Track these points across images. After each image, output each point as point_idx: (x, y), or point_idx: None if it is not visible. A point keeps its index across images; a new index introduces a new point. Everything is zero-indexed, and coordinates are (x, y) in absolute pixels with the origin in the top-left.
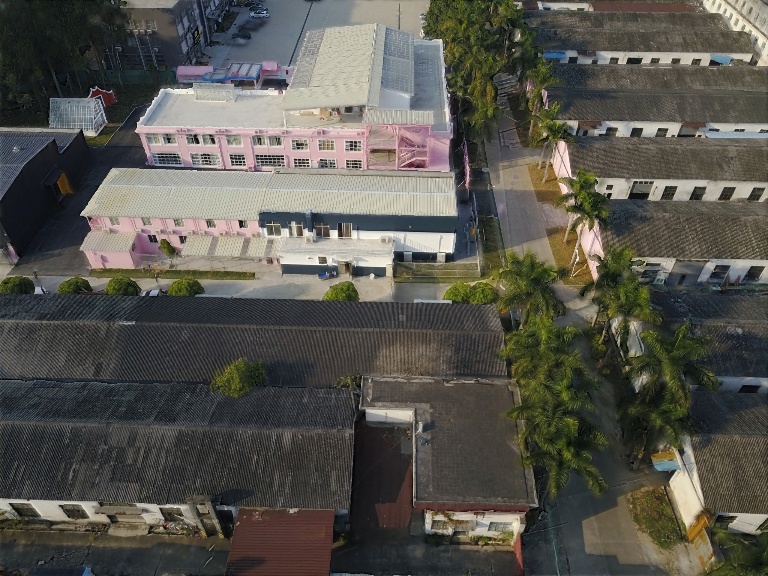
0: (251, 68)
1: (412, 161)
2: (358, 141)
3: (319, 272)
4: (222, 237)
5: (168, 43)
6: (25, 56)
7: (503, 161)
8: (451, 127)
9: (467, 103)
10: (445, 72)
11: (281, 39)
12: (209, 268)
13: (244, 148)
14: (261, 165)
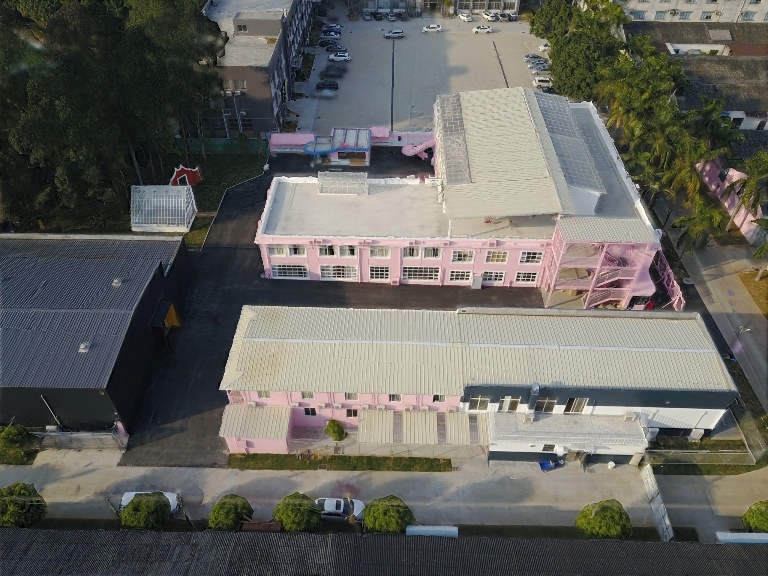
0: (359, 135)
1: (613, 281)
2: (538, 252)
3: (538, 459)
4: (407, 412)
5: (258, 105)
6: (109, 143)
7: (705, 267)
8: (660, 236)
9: (661, 196)
10: (618, 151)
11: (372, 89)
12: (388, 452)
13: (390, 260)
14: (408, 278)
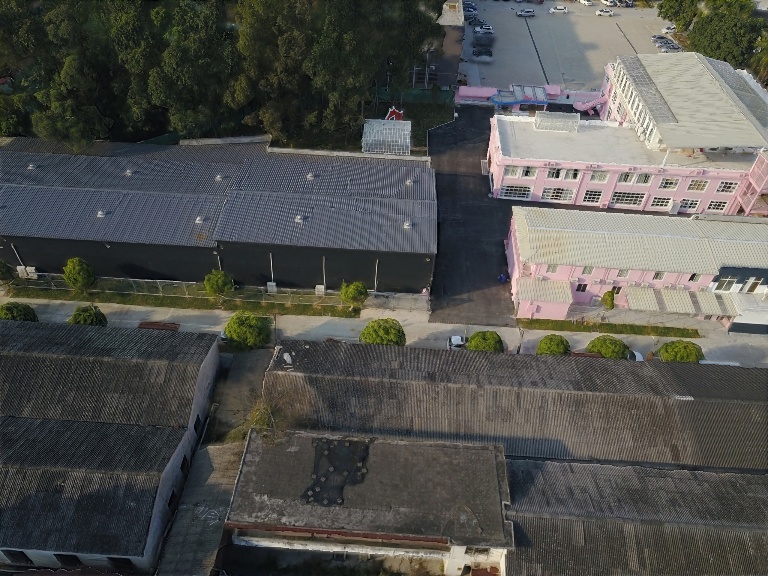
0: (535, 91)
1: None
2: (735, 182)
3: None
4: (664, 290)
5: (447, 61)
6: None
7: None
8: None
9: None
10: None
11: (521, 58)
12: (645, 322)
13: (606, 184)
14: (615, 202)
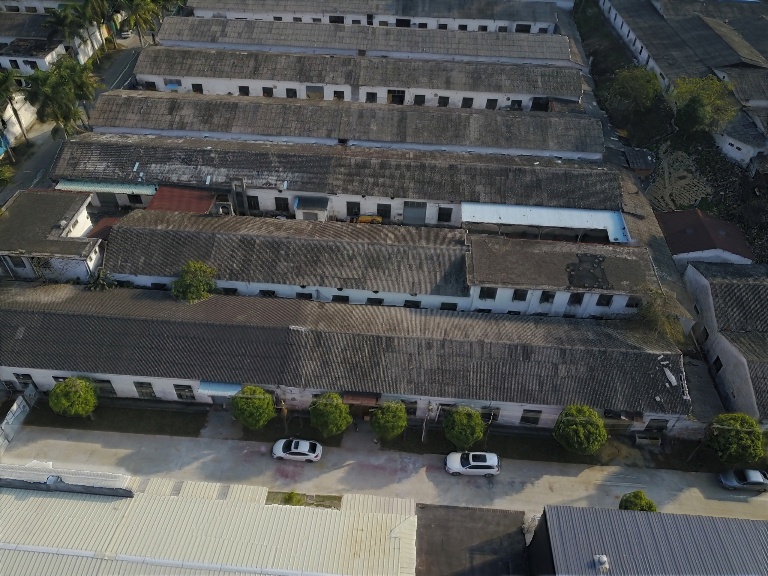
0: None
1: None
2: None
3: None
4: None
5: None
6: None
7: None
8: None
9: None
10: None
11: None
12: None
13: None
14: None
